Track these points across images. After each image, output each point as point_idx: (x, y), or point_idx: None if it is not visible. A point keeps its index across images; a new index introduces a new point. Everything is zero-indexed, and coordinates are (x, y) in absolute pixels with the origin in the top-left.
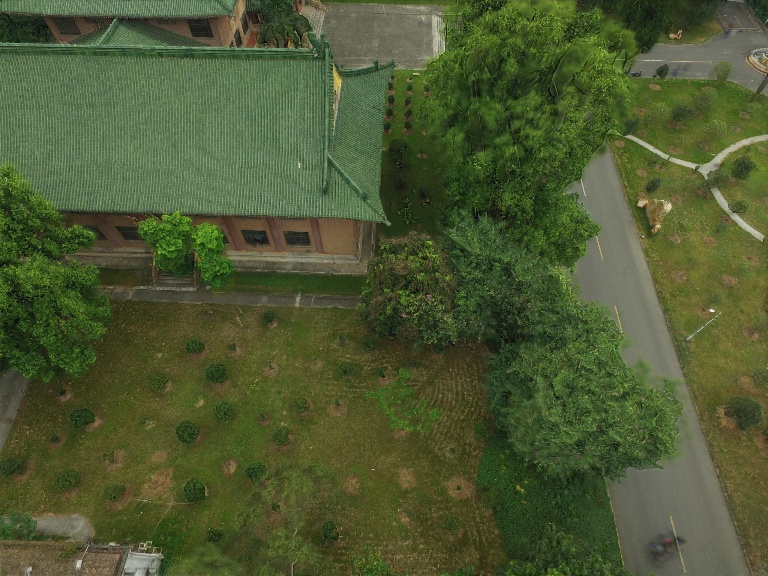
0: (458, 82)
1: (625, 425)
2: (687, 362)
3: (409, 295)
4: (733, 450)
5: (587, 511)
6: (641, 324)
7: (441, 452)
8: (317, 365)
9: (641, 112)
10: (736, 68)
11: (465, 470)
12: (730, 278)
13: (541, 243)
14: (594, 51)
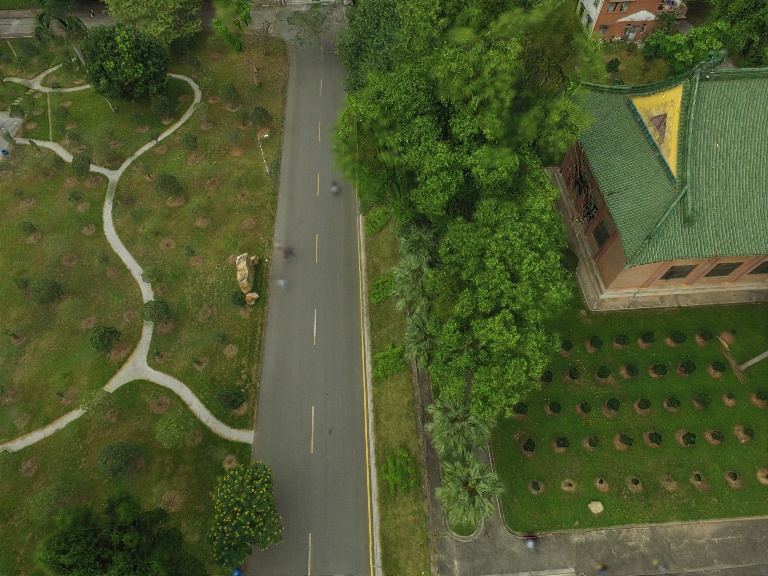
0: None
1: None
2: (276, 161)
3: None
4: None
5: None
6: (300, 185)
7: None
8: None
9: (171, 499)
10: None
11: None
12: (201, 224)
13: None
14: None
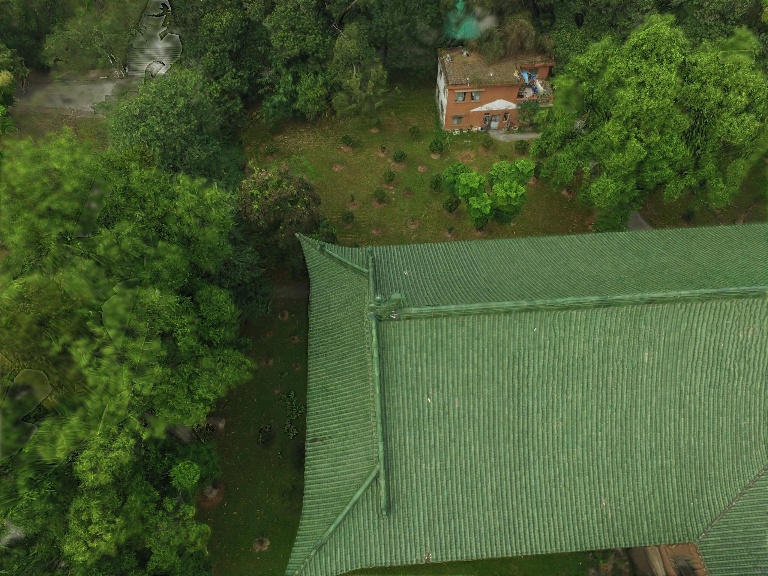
0: None
1: None
2: None
3: None
4: None
5: None
6: None
7: None
8: (375, 230)
9: None
10: None
11: None
12: None
13: None
14: None
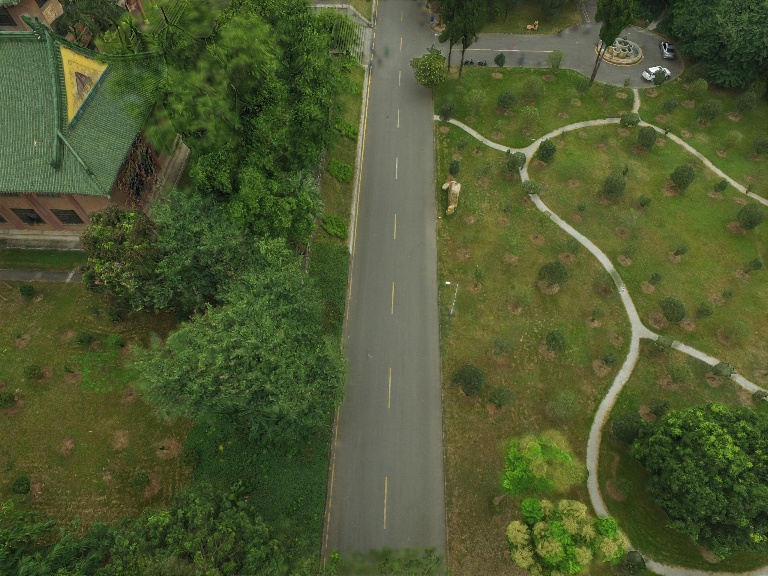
0: (208, 65)
1: (211, 374)
2: (445, 334)
3: (104, 263)
4: (463, 416)
5: (282, 469)
6: (413, 299)
7: (160, 415)
8: (68, 336)
9: None
10: (583, 57)
11: (178, 432)
12: (511, 256)
13: (241, 214)
14: (298, 32)
